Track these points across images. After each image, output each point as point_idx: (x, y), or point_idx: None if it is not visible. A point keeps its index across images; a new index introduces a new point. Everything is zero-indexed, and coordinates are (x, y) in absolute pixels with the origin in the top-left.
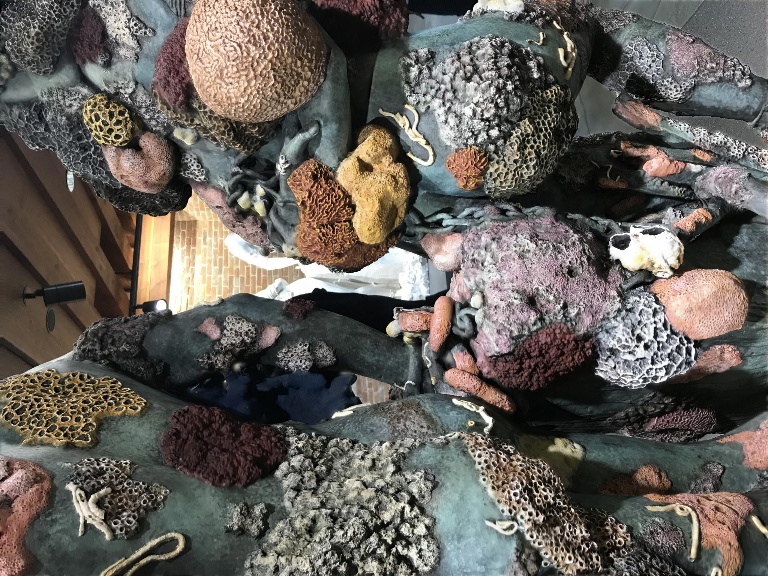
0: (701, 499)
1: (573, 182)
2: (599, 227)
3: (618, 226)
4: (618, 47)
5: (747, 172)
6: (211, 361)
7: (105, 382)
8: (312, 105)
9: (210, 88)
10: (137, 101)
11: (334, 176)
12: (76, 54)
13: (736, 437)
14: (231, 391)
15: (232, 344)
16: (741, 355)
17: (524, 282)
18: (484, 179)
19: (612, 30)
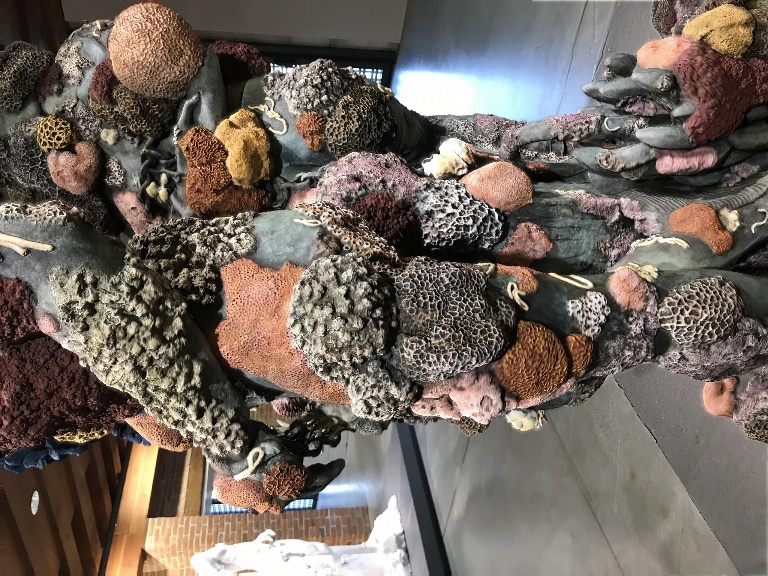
0: None
1: None
2: None
3: None
4: (443, 128)
5: None
6: None
7: None
8: (195, 83)
9: (121, 57)
10: (77, 113)
11: (212, 134)
12: (40, 95)
13: None
14: None
15: None
16: (548, 237)
17: (352, 171)
18: (325, 136)
19: (437, 121)
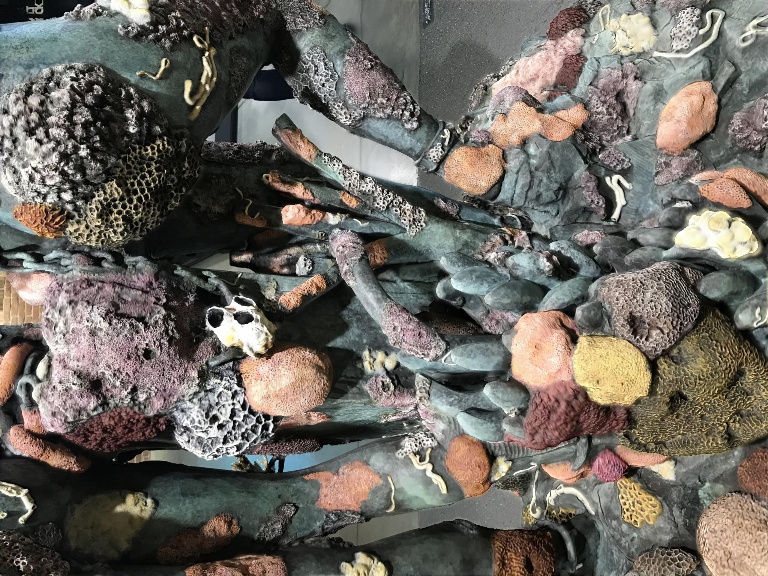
0: (237, 575)
1: (210, 211)
2: (207, 287)
3: (226, 289)
4: (297, 52)
5: (361, 253)
6: None
7: None
8: None
9: None
10: None
11: None
12: None
13: (319, 476)
14: None
15: None
16: (329, 416)
17: (90, 363)
18: (64, 234)
19: (294, 29)
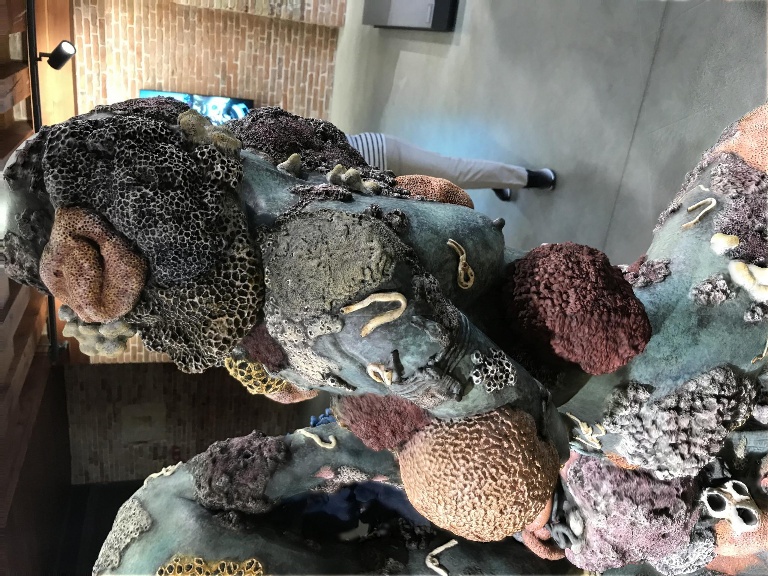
0: None
1: None
2: None
3: (720, 466)
4: None
5: None
6: (321, 489)
7: (249, 571)
8: None
9: None
10: None
11: None
12: None
13: None
14: (333, 501)
15: (342, 481)
16: None
17: (625, 542)
18: None
19: None
